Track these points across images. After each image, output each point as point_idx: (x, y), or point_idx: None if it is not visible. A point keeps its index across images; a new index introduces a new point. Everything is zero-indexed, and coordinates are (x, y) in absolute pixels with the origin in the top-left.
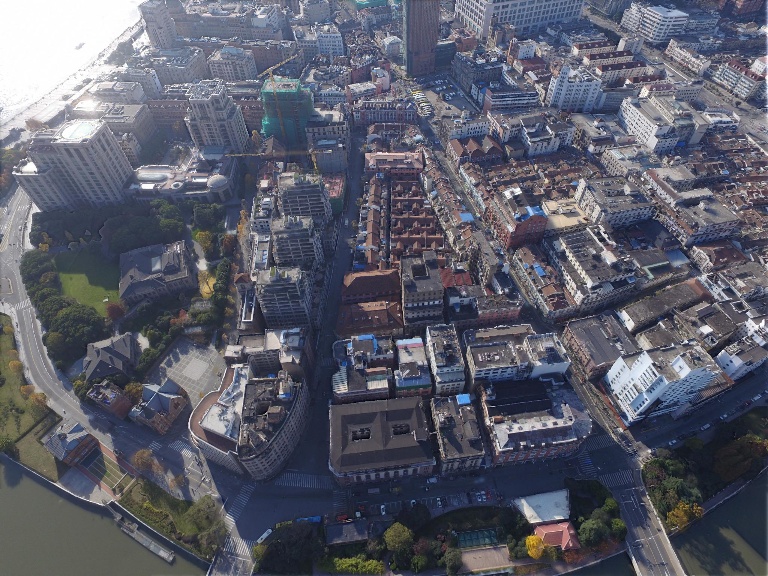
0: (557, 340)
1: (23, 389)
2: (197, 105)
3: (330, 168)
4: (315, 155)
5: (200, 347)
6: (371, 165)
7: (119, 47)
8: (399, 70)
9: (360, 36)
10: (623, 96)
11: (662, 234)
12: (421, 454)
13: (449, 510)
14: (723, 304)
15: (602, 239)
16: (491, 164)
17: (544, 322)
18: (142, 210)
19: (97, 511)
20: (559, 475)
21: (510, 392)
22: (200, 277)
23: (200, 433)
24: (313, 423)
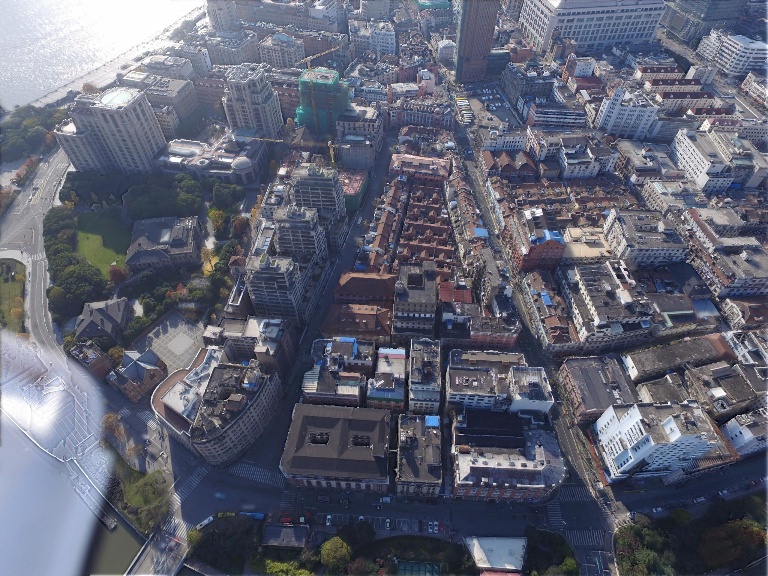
0: (544, 376)
1: (18, 336)
2: (234, 86)
3: (355, 164)
4: (341, 149)
5: (190, 323)
6: (395, 166)
7: (183, 24)
8: (448, 75)
9: (414, 36)
10: (681, 127)
11: (692, 280)
12: (375, 470)
13: (396, 534)
14: (745, 367)
15: (621, 276)
16: (522, 181)
17: (542, 354)
18: (166, 182)
19: (56, 466)
20: (522, 521)
21: (483, 422)
22: (203, 254)
23: (160, 408)
24: (280, 418)
